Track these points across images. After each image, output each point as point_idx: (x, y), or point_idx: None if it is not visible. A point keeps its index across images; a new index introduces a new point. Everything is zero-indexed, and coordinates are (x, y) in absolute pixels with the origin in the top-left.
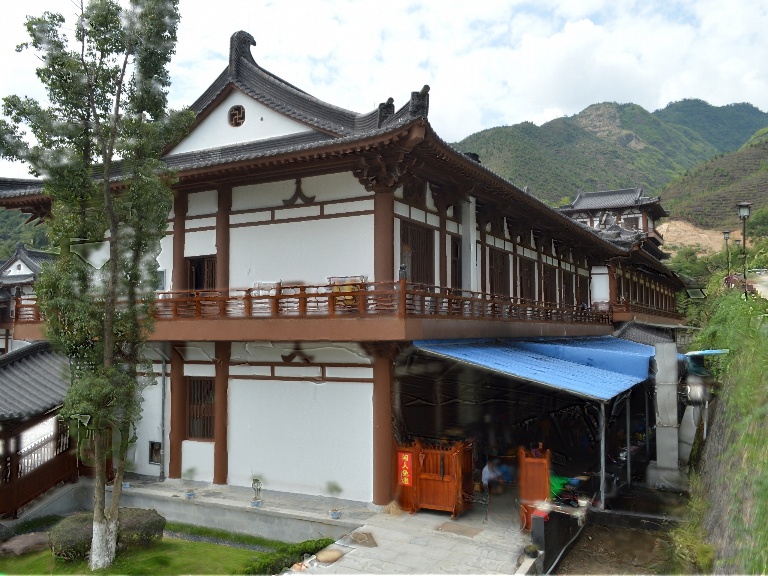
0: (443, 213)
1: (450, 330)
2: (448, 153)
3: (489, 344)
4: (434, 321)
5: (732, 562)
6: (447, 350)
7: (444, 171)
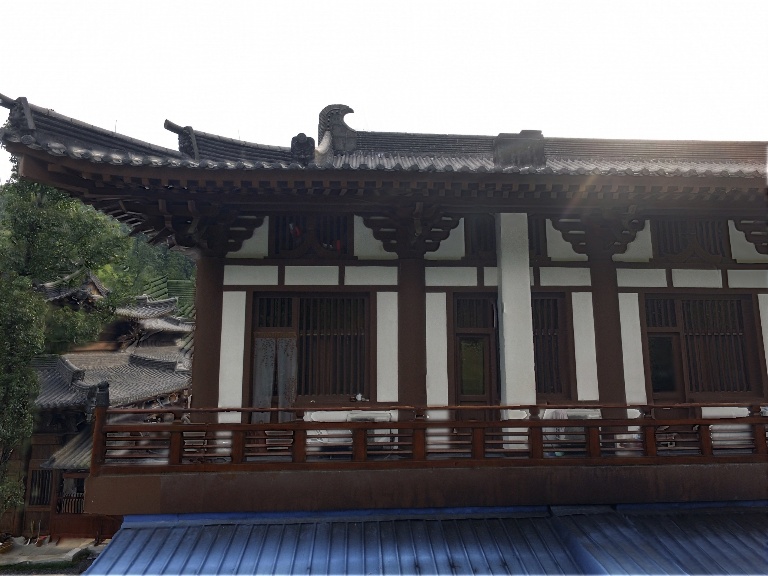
0: (404, 259)
1: (287, 492)
2: (172, 175)
3: (467, 525)
4: (211, 477)
5: None
6: (169, 550)
7: (307, 196)
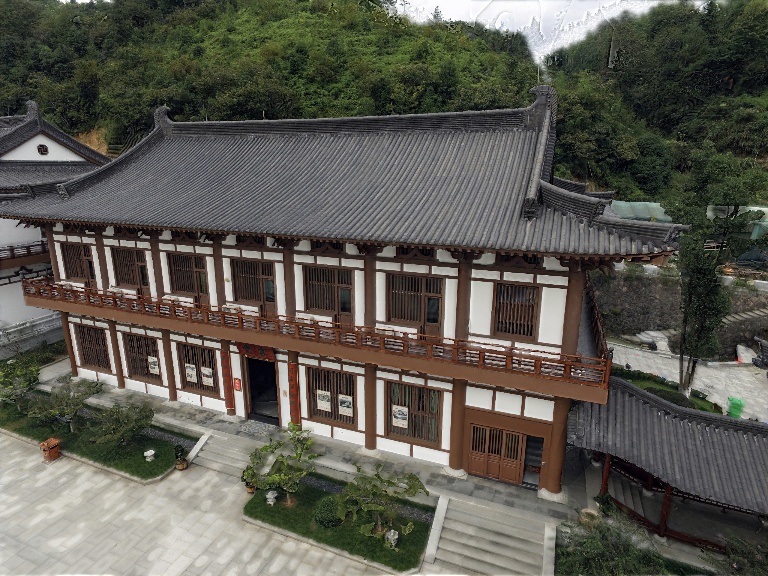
0: None
1: None
2: None
3: None
4: None
5: (650, 305)
6: None
7: None
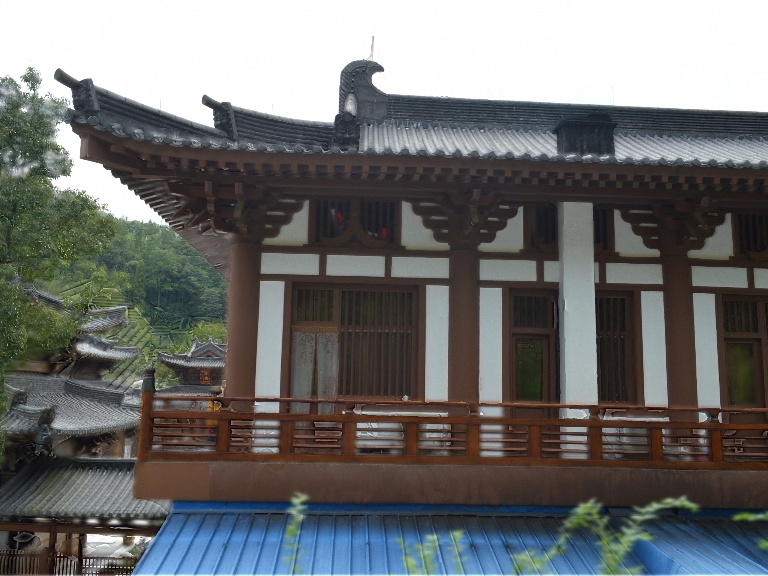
0: (457, 250)
1: (336, 484)
2: (229, 157)
3: (521, 521)
4: (260, 466)
5: None
6: None
7: None
